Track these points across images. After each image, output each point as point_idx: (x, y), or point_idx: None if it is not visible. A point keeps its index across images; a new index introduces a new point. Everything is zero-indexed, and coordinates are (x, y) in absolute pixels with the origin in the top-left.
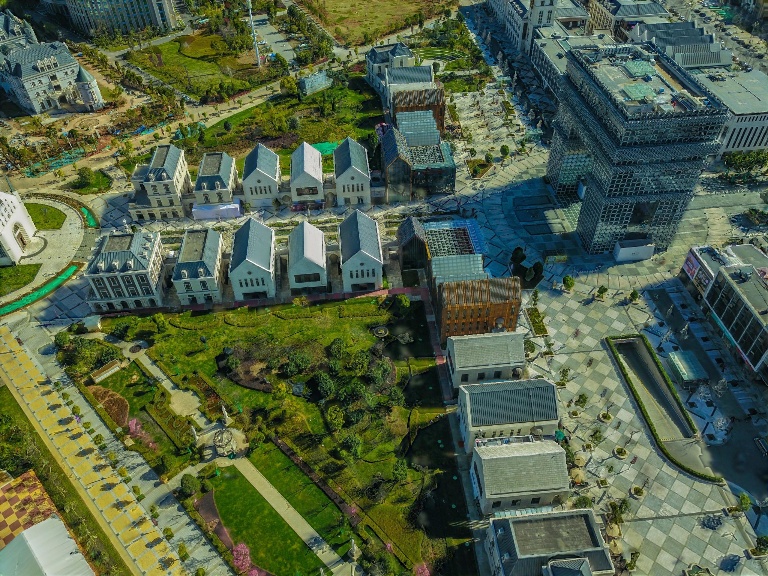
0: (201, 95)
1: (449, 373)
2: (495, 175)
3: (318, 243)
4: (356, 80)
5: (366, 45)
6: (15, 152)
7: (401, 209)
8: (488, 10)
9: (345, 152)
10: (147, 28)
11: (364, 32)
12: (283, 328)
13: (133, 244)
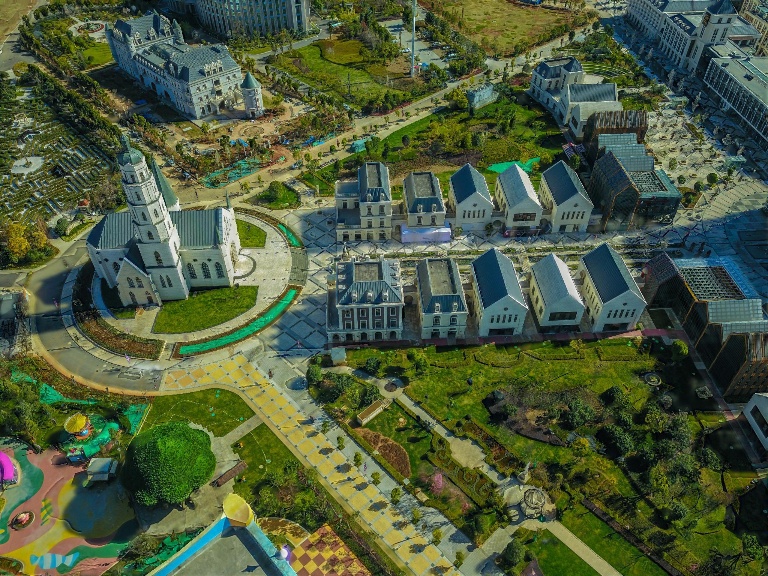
0: (364, 105)
1: (747, 431)
2: (708, 205)
3: (570, 278)
4: (520, 94)
5: (516, 57)
6: (194, 161)
7: (620, 239)
8: (631, 23)
9: (562, 176)
10: (283, 31)
11: (509, 42)
12: (543, 370)
13: (385, 274)
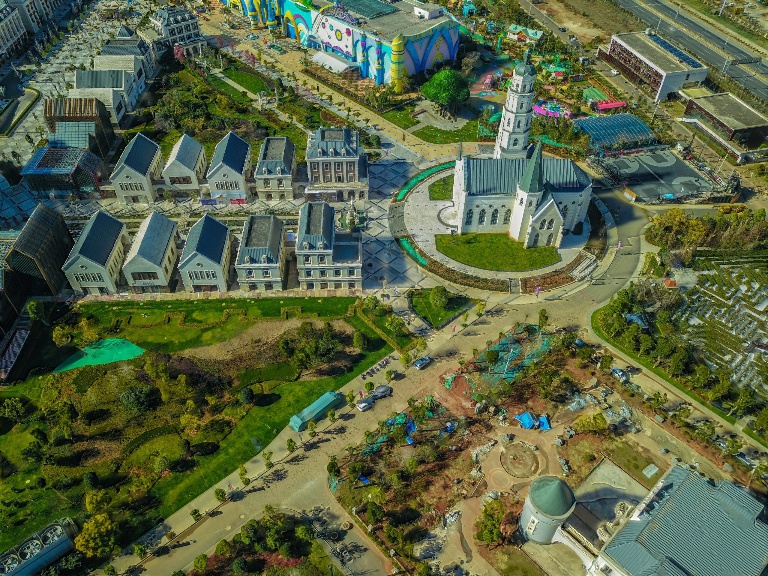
0: None
1: None
2: None
3: None
4: None
5: None
6: None
7: None
8: None
9: (94, 240)
10: None
11: None
12: None
13: None
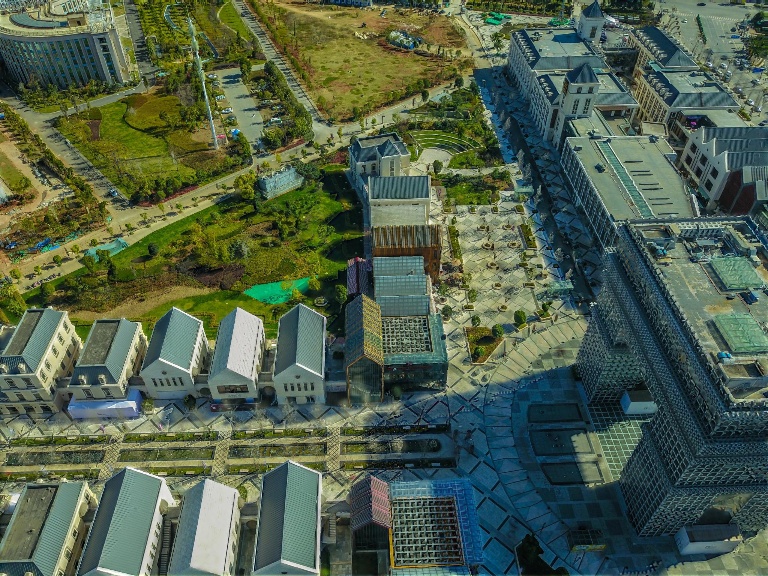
0: (132, 192)
1: None
2: (504, 358)
3: (223, 520)
4: (334, 177)
5: (354, 121)
6: None
7: (367, 416)
8: (509, 76)
9: (292, 330)
10: (91, 83)
11: (355, 101)
12: None
13: None
